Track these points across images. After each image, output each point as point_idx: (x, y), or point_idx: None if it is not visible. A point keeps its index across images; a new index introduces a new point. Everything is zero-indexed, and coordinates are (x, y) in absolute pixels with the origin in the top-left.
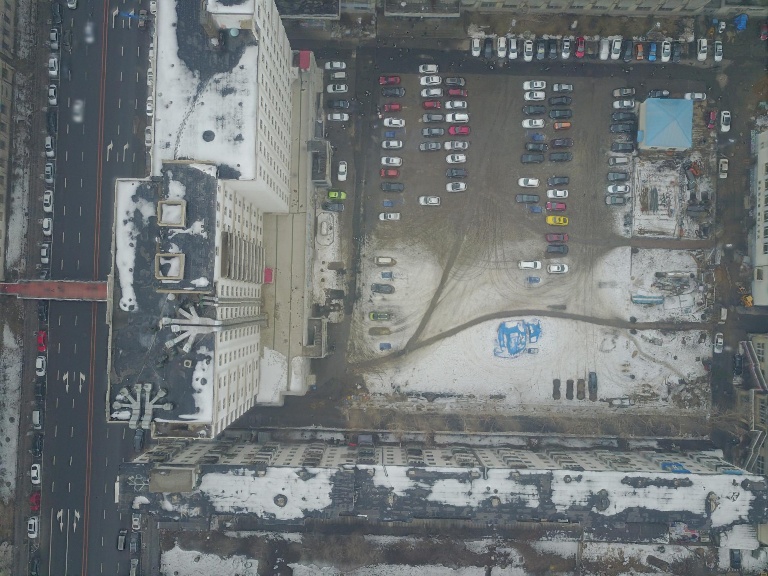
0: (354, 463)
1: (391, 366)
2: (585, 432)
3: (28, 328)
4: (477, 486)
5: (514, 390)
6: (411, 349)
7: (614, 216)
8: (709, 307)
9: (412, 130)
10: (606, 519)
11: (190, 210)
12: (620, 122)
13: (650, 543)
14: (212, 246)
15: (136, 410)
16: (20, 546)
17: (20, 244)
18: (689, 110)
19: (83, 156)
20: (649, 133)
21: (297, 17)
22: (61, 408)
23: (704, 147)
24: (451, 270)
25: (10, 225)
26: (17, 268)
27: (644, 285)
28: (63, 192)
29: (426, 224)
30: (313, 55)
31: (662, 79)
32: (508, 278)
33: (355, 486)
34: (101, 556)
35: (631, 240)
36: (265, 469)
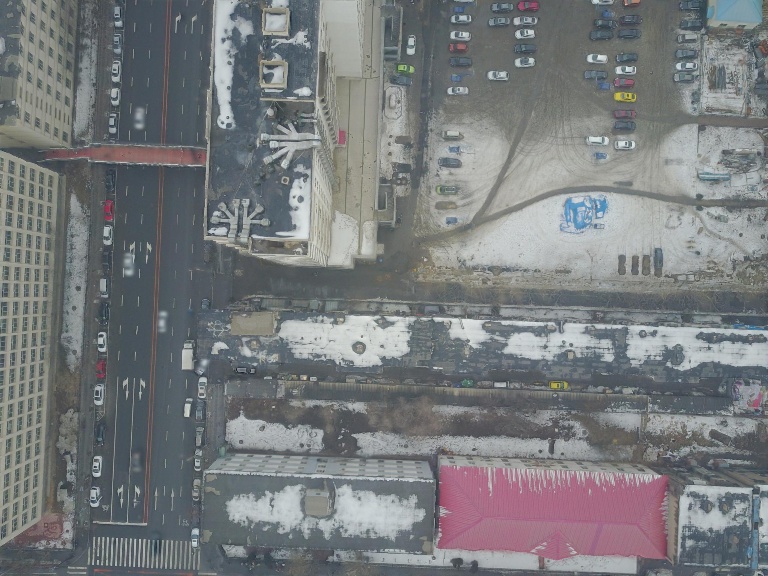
0: (430, 316)
1: (457, 240)
2: (649, 308)
3: (95, 198)
4: (553, 340)
5: (579, 265)
6: (477, 223)
7: (682, 94)
8: None
9: (481, 6)
10: (680, 374)
11: (293, 20)
12: None
13: (714, 415)
14: (315, 56)
15: (234, 225)
16: (86, 413)
17: (88, 114)
18: None
19: (151, 28)
20: (720, 7)
21: None
22: (127, 278)
23: None
24: (518, 145)
25: (78, 95)
26: (84, 138)
27: (711, 162)
28: (131, 63)
29: (494, 99)
30: None
31: None
32: (575, 154)
33: (431, 338)
34: (166, 424)
35: (698, 118)
36: (344, 317)
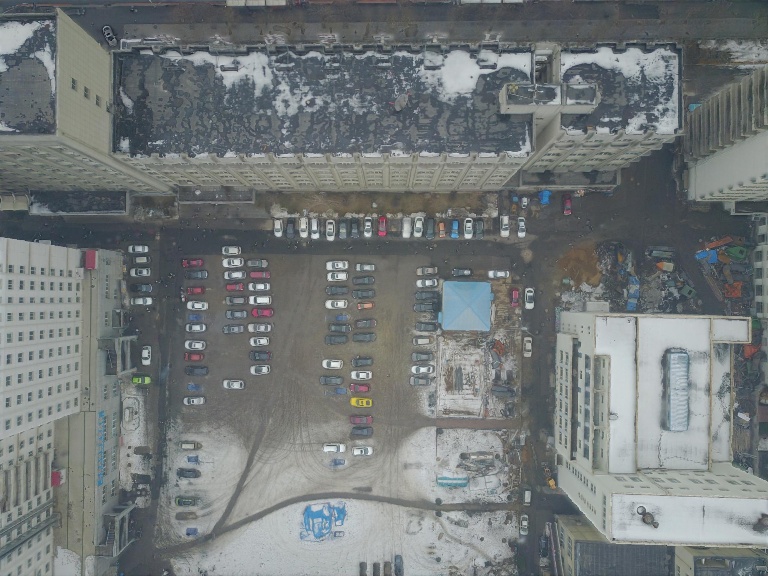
0: None
1: (198, 551)
2: None
3: None
4: None
5: (321, 574)
6: (218, 533)
7: (419, 396)
8: (514, 489)
9: (216, 312)
10: None
11: None
12: (423, 301)
13: None
14: None
15: None
16: None
17: None
18: (486, 294)
19: None
20: (446, 318)
21: (85, 214)
22: None
23: (509, 325)
24: (257, 453)
25: None
26: None
27: (450, 466)
28: None
29: (231, 407)
30: (102, 252)
31: (466, 256)
32: (314, 460)
33: None
34: None
35: (436, 420)
36: None
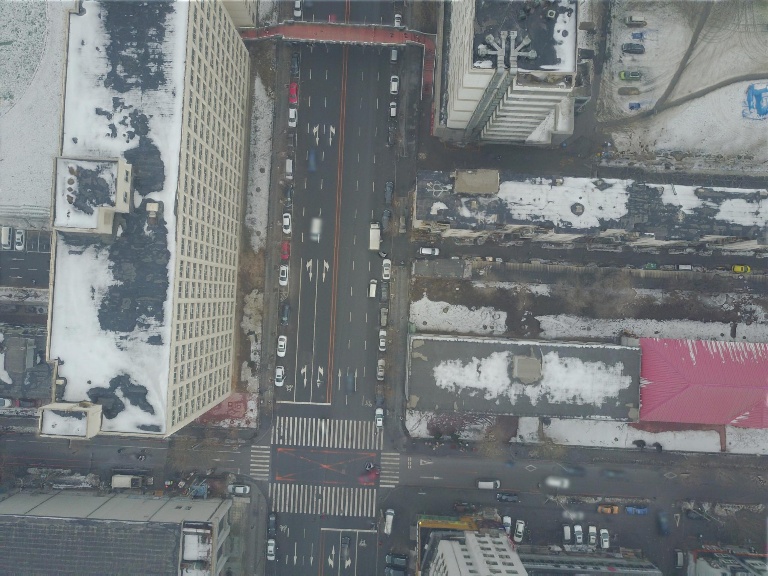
0: (641, 183)
1: (640, 125)
2: None
3: (279, 81)
4: (765, 206)
5: (762, 151)
6: (660, 109)
7: None
8: None
9: None
10: None
11: None
12: None
13: None
14: None
15: (502, 56)
16: (270, 294)
17: None
18: None
19: None
20: None
21: None
22: (311, 161)
23: None
24: (701, 32)
25: None
26: (269, 21)
27: None
28: None
29: None
30: None
31: None
32: (757, 41)
33: None
34: (350, 306)
35: None
36: (562, 178)
